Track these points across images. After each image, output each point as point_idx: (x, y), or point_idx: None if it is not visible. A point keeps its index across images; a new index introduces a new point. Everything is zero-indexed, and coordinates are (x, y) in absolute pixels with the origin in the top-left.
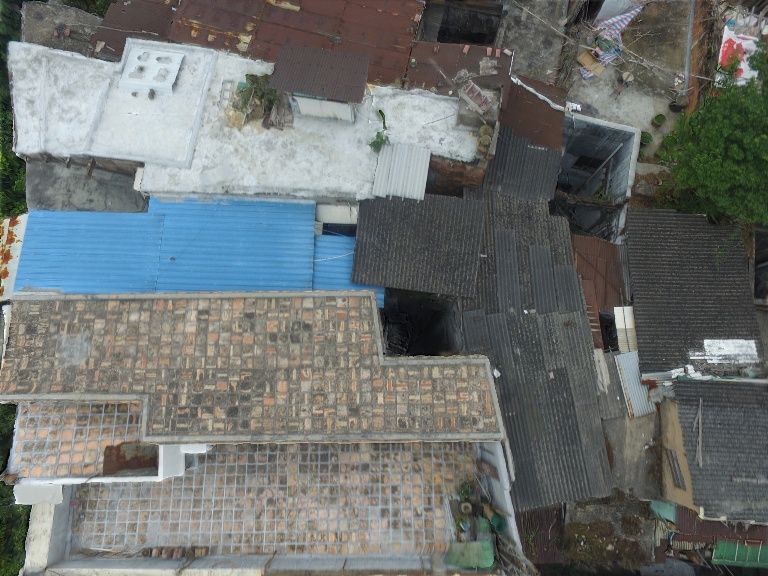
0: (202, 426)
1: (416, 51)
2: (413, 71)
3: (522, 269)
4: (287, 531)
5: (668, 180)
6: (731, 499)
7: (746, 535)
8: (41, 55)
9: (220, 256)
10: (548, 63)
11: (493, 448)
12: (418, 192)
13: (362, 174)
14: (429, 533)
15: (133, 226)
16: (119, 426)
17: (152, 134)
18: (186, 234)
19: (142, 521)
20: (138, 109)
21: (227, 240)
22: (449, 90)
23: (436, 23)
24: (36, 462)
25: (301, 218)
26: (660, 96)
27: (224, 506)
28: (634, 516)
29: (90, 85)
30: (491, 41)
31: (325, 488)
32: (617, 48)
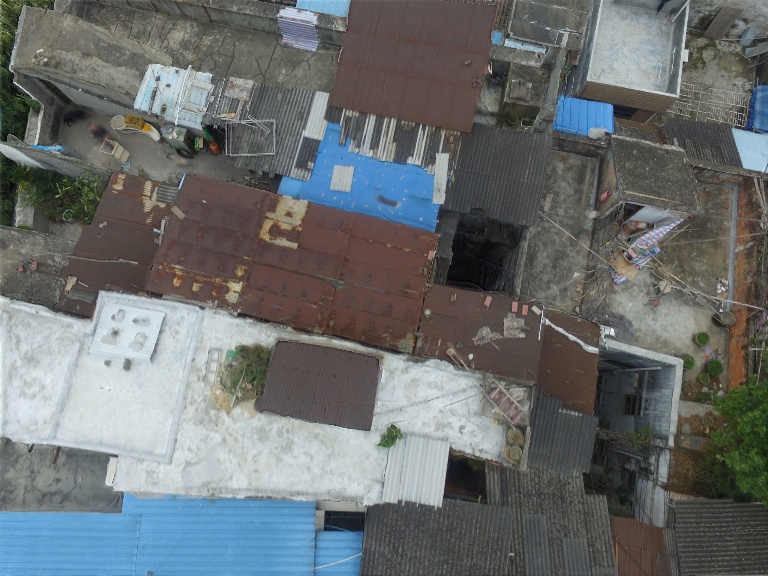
0: None
1: (430, 297)
2: (427, 322)
3: (555, 572)
4: None
5: (716, 428)
6: None
7: None
8: (2, 310)
9: (205, 567)
10: (575, 264)
11: None
12: (435, 497)
13: (370, 470)
14: None
15: (105, 530)
16: None
17: (127, 416)
18: (166, 539)
19: None
20: (111, 383)
21: (214, 545)
22: (469, 353)
23: (450, 230)
24: None
25: (299, 514)
26: (701, 306)
27: None
28: None
29: (57, 350)
30: (512, 246)
31: None
32: (652, 250)
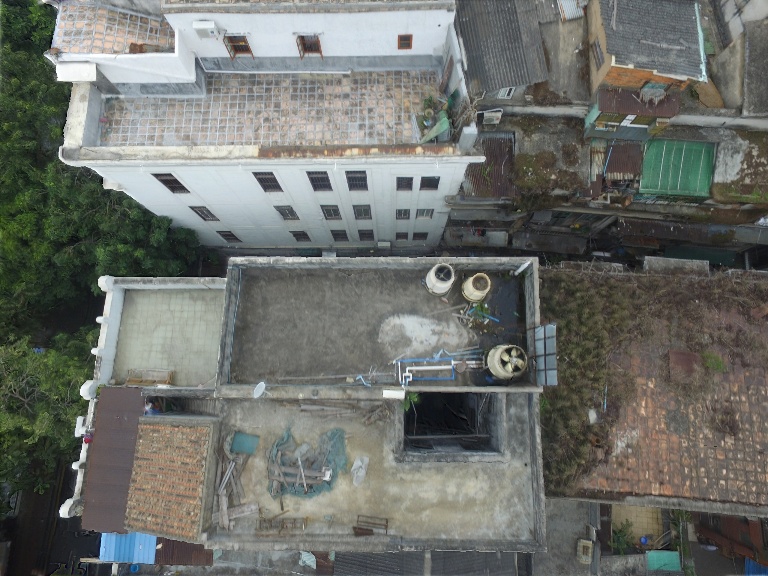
0: (211, 0)
1: None
2: None
3: None
4: (280, 140)
5: None
6: (638, 54)
7: (656, 110)
8: None
9: None
10: None
11: (449, 40)
12: None
13: None
14: (399, 140)
15: None
16: (141, 33)
17: None
18: None
19: (159, 133)
20: None
21: None
22: None
23: None
24: (75, 43)
25: None
26: None
27: (228, 124)
28: (572, 144)
29: None
30: None
31: (312, 111)
32: None
